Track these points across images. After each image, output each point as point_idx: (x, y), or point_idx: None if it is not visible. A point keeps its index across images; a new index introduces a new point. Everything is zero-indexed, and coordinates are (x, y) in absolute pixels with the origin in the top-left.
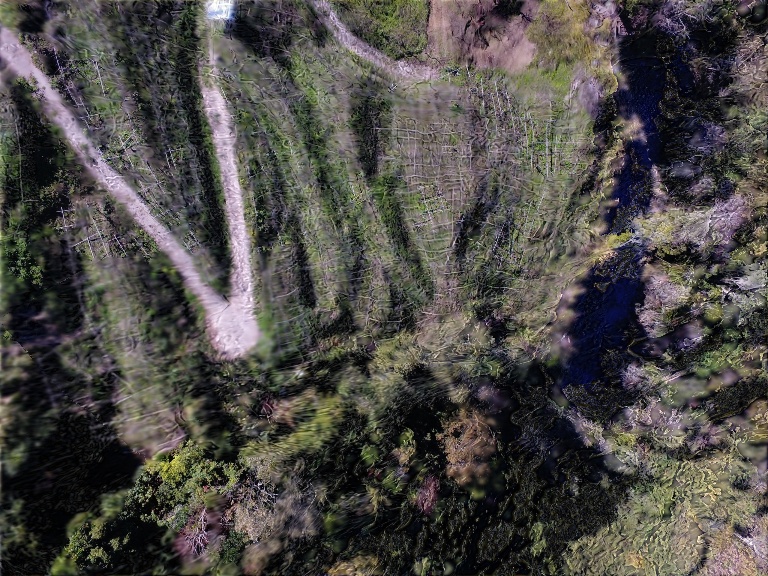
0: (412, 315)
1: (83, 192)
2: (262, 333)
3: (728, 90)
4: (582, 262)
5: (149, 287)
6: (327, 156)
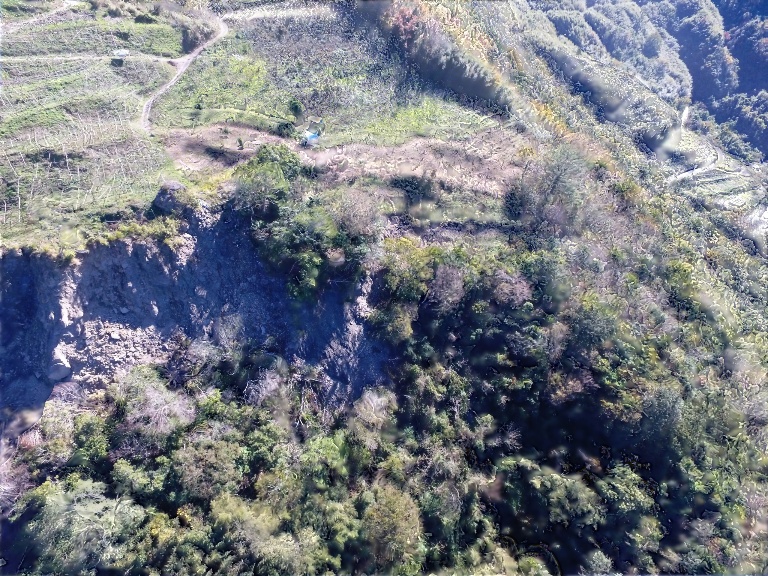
0: None
1: (24, 10)
2: None
3: (361, 420)
4: (51, 236)
5: None
6: (84, 87)
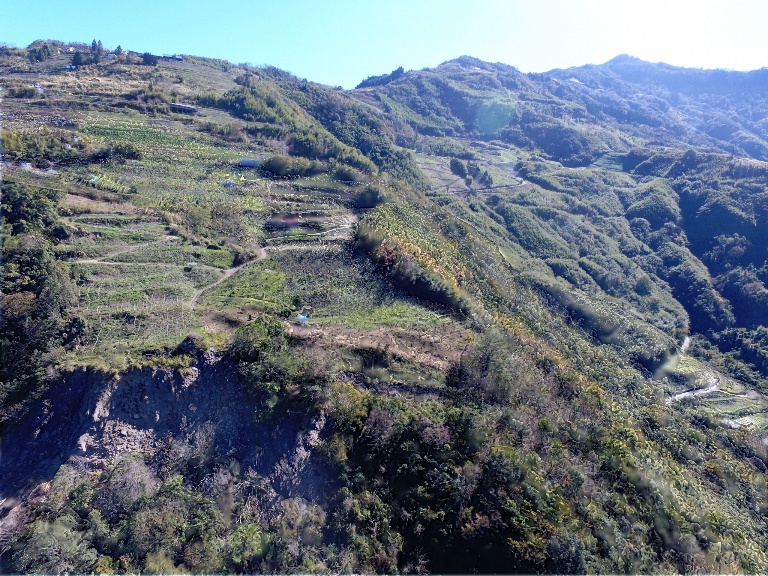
0: (90, 300)
1: None
2: (93, 261)
3: None
4: None
5: (114, 246)
6: None
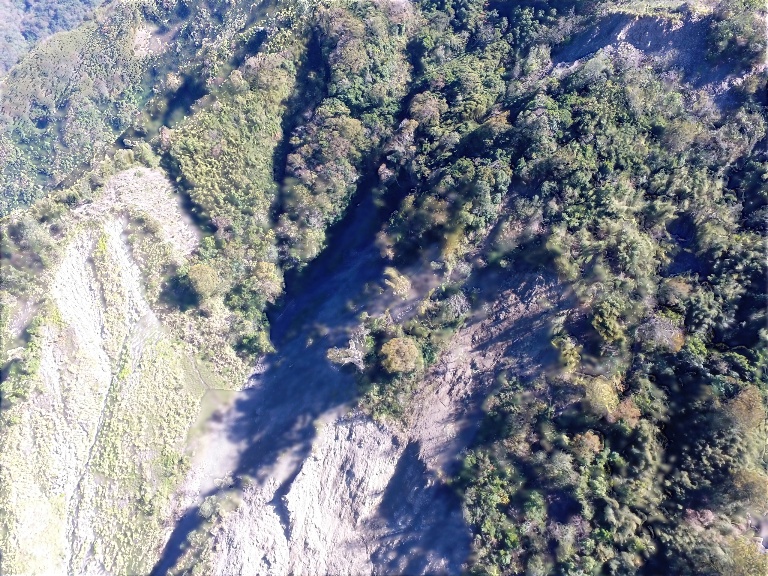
0: None
1: None
2: None
3: None
4: None
5: None
6: None
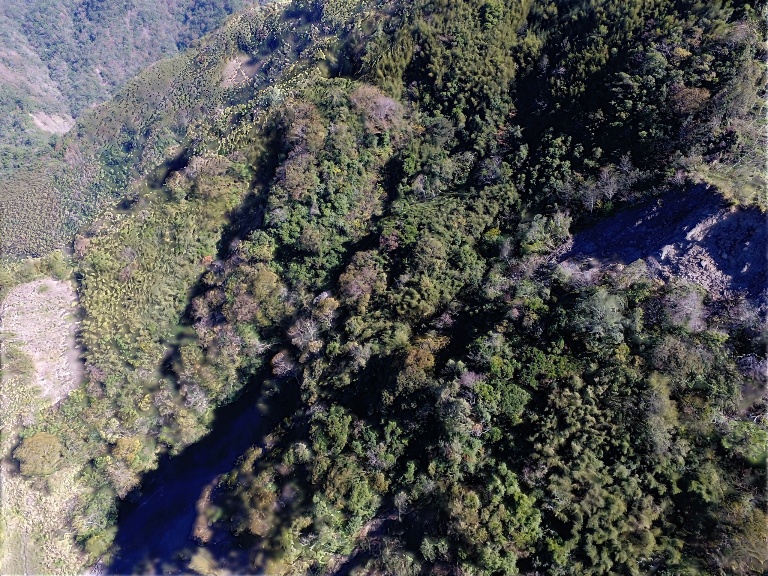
0: None
1: None
2: None
3: None
4: None
5: None
6: None
